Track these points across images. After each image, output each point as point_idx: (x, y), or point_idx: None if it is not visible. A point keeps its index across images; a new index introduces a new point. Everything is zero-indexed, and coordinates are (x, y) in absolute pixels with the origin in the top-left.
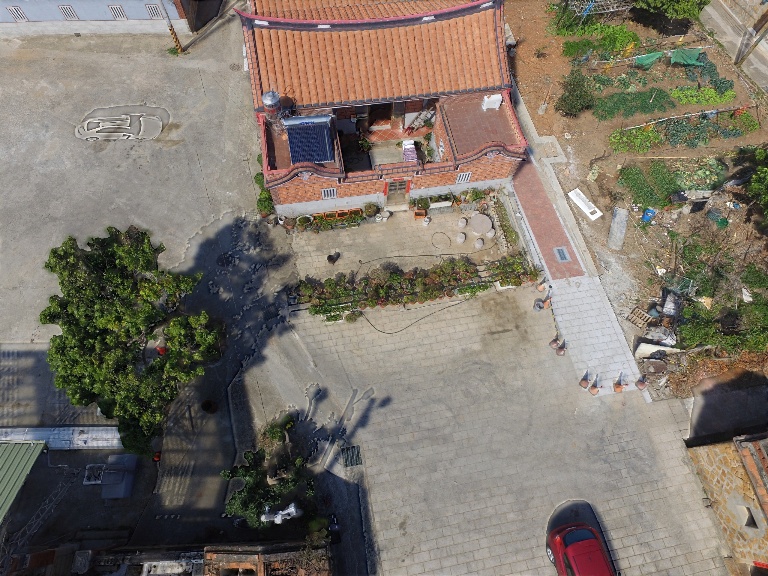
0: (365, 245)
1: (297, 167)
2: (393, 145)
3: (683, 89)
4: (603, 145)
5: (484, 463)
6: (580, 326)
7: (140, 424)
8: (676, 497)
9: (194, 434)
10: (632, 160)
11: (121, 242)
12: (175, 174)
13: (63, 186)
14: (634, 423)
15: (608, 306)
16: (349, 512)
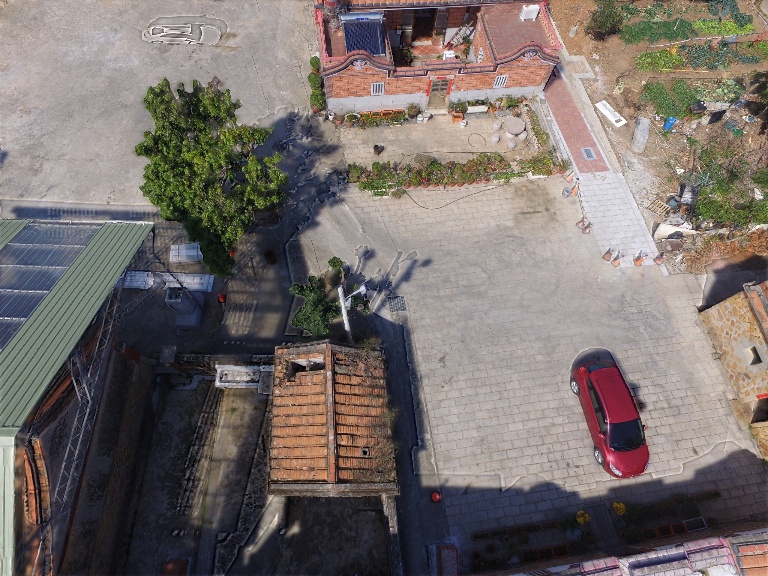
0: (407, 141)
1: (353, 54)
2: (433, 59)
3: (705, 21)
4: (629, 65)
5: (516, 315)
6: (604, 211)
7: (222, 240)
8: (688, 351)
9: (256, 280)
10: (656, 78)
11: None
12: (233, 75)
13: (132, 79)
14: (652, 291)
15: (630, 197)
16: (395, 346)
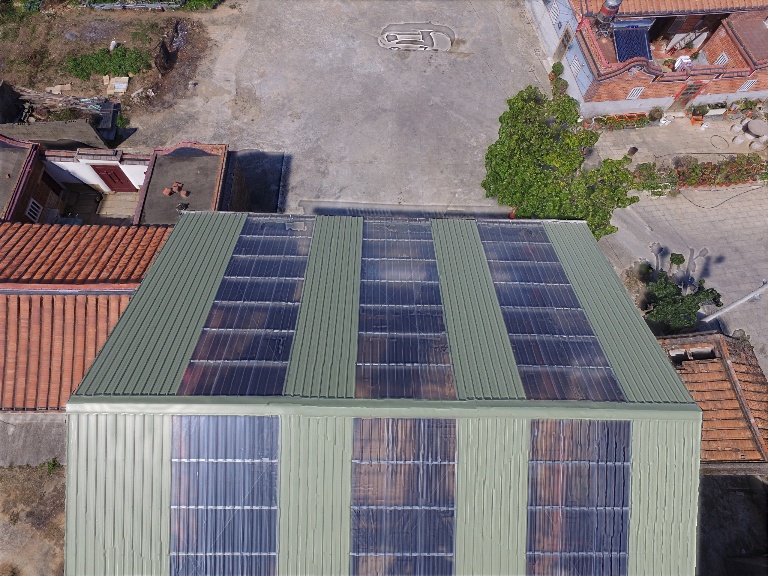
0: (654, 143)
1: (635, 61)
2: (659, 63)
3: None
4: None
5: None
6: None
7: None
8: None
9: None
10: None
11: (540, 102)
12: (475, 80)
13: (384, 85)
14: None
15: None
16: None
